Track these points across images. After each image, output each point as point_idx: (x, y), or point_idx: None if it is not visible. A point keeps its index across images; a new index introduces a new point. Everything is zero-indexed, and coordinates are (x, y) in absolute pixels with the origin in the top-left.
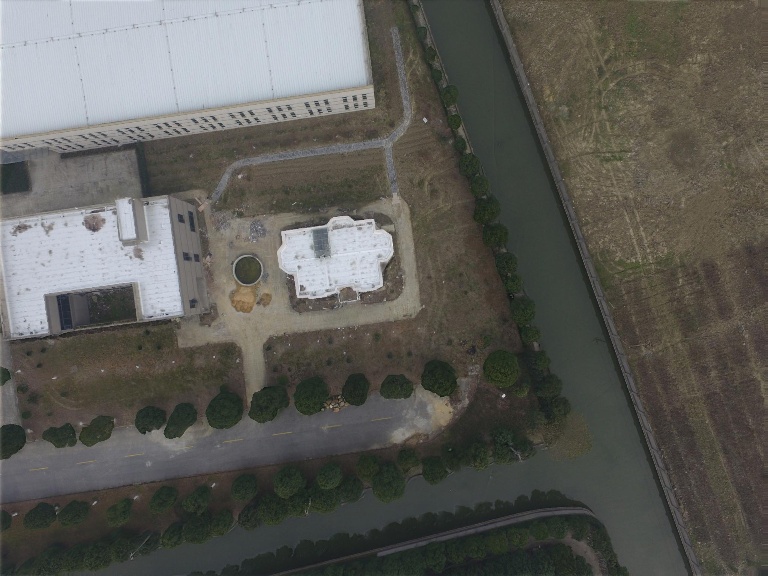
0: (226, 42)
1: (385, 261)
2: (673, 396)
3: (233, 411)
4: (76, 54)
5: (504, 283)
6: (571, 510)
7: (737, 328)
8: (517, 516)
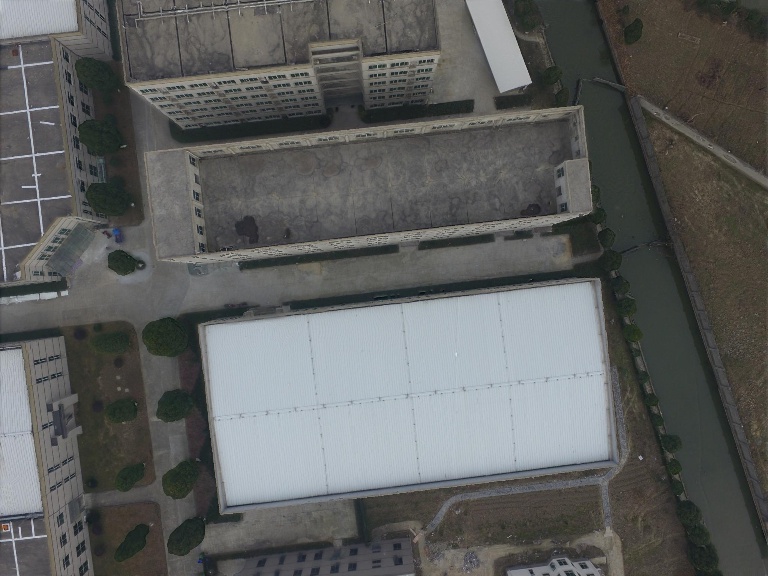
0: (472, 416)
1: None
2: None
3: None
4: (319, 424)
5: None
6: None
7: None
8: None
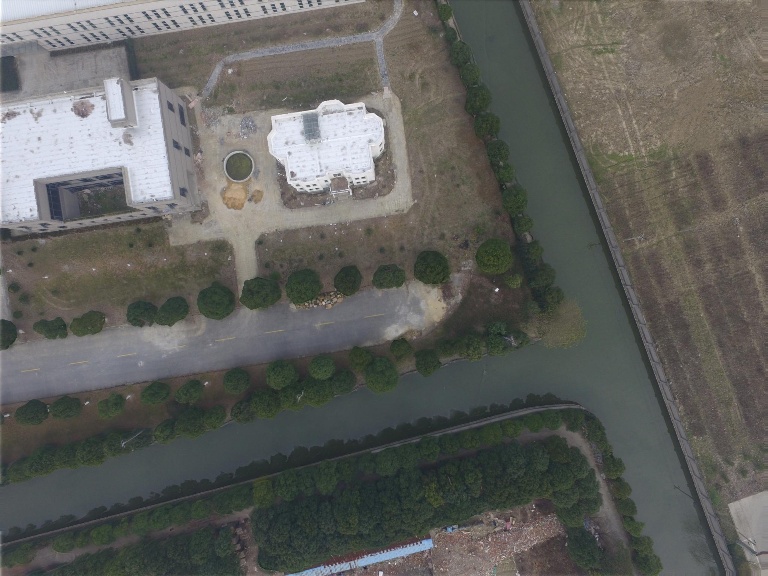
0: None
1: (376, 145)
2: (667, 289)
3: (224, 299)
4: None
5: (496, 172)
6: (566, 406)
7: (731, 220)
8: (512, 413)
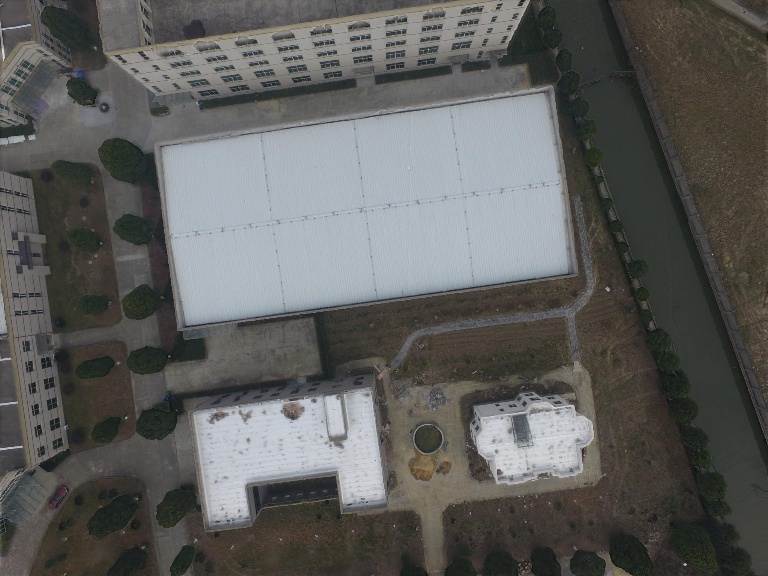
0: (427, 229)
1: (584, 446)
2: None
3: None
4: (274, 241)
5: (693, 458)
6: None
7: None
8: None
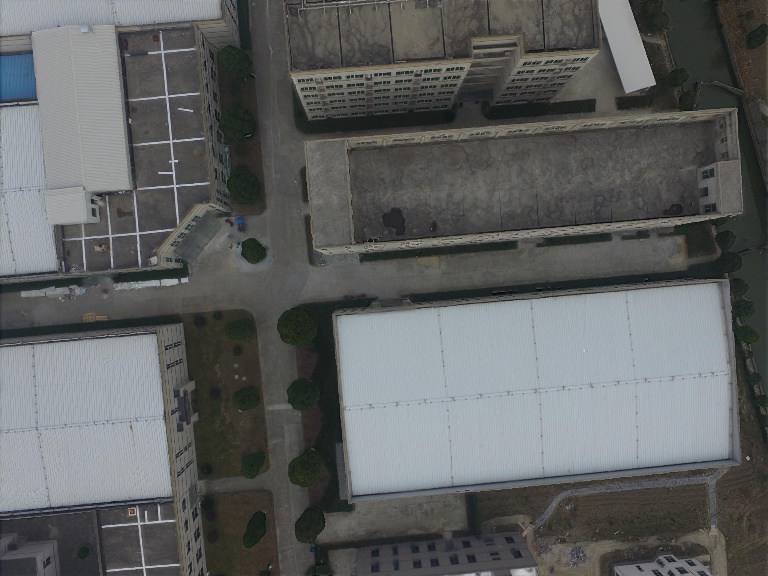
0: (598, 412)
1: None
2: None
3: None
4: (448, 417)
5: None
6: None
7: None
8: None
